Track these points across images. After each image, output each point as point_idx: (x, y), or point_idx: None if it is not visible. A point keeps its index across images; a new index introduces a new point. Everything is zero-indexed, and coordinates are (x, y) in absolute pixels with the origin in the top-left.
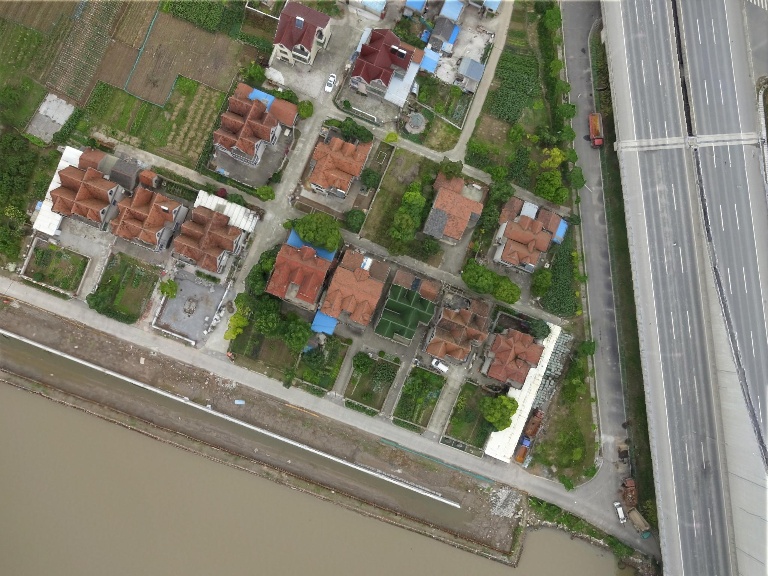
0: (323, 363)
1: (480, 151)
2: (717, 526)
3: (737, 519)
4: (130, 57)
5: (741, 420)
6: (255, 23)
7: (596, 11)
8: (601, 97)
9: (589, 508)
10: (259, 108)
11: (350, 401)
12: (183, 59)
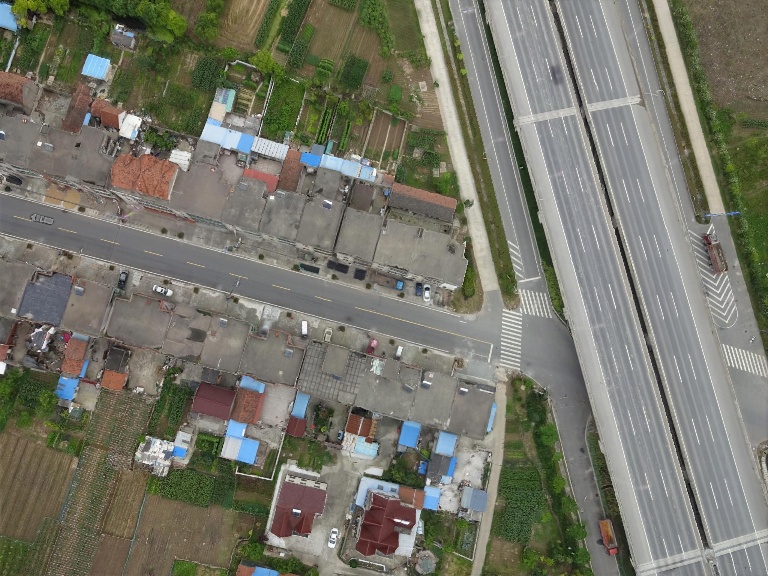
0: None
1: None
2: None
3: None
4: (122, 548)
5: None
6: (248, 487)
7: (589, 410)
8: (607, 496)
9: None
10: None
11: None
12: (177, 540)
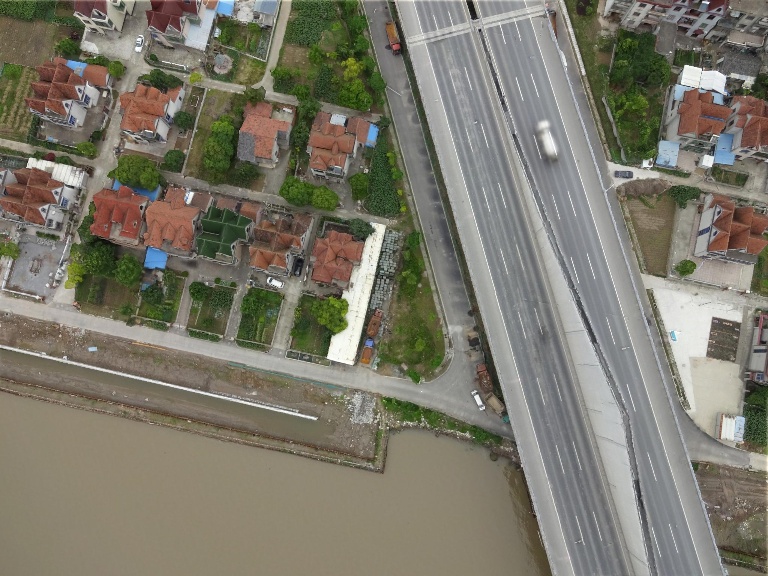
0: (163, 298)
1: (281, 75)
2: (565, 391)
3: (580, 378)
4: None
5: (556, 272)
6: (67, 6)
7: None
8: None
9: (447, 401)
10: (65, 71)
11: (192, 330)
12: (7, 49)
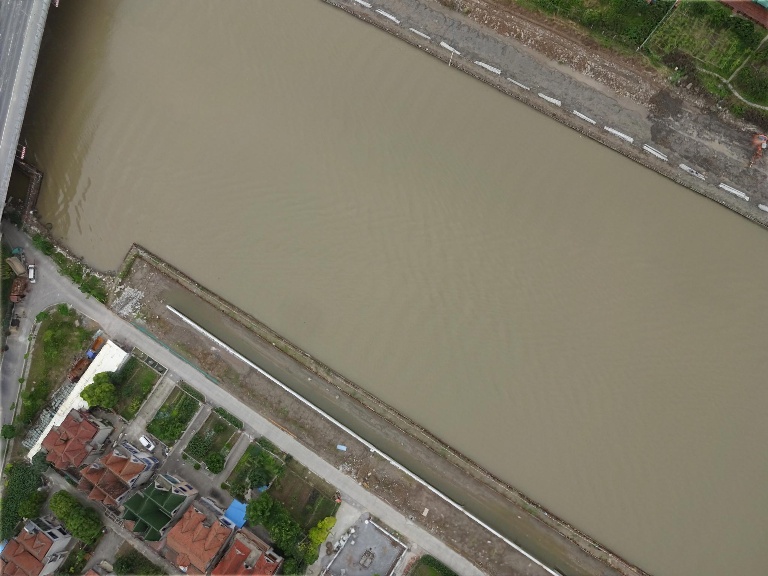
0: None
1: None
2: None
3: None
4: None
5: None
6: None
7: None
8: None
9: (58, 282)
10: None
11: None
12: None
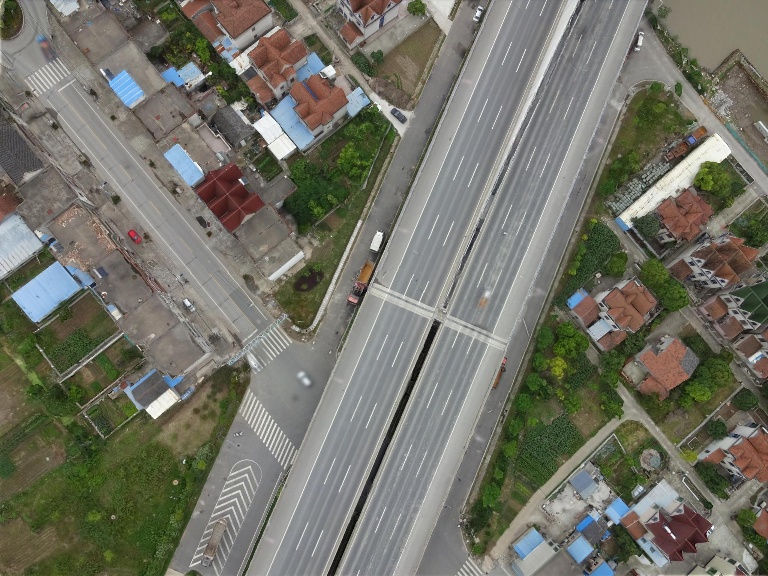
0: None
1: None
2: None
3: None
4: None
5: None
6: None
7: None
8: None
9: (659, 60)
10: None
11: None
12: None
